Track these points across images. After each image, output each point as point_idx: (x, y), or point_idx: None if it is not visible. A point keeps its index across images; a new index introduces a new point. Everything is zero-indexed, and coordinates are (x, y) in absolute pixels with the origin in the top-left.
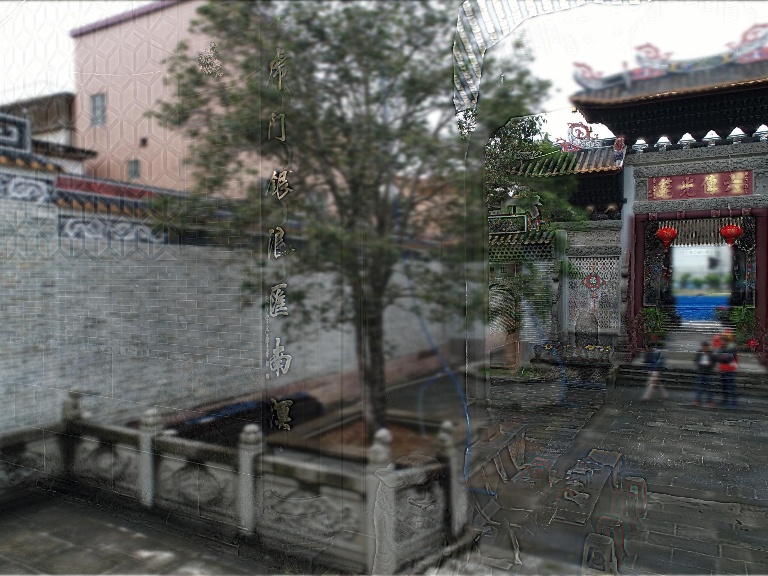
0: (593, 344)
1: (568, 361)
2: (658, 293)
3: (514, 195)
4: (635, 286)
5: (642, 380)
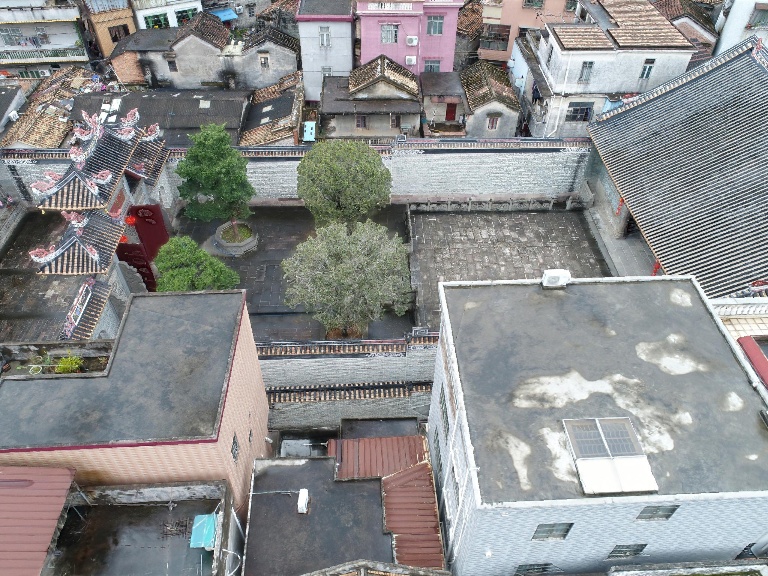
0: None
1: None
2: (621, 226)
3: (553, 34)
4: None
5: None
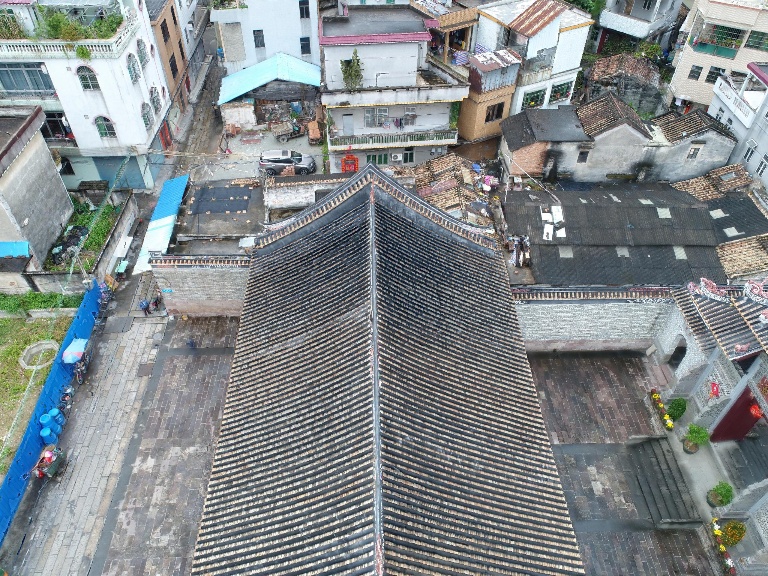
0: (671, 417)
1: (656, 411)
2: None
3: None
4: (727, 414)
5: (655, 453)
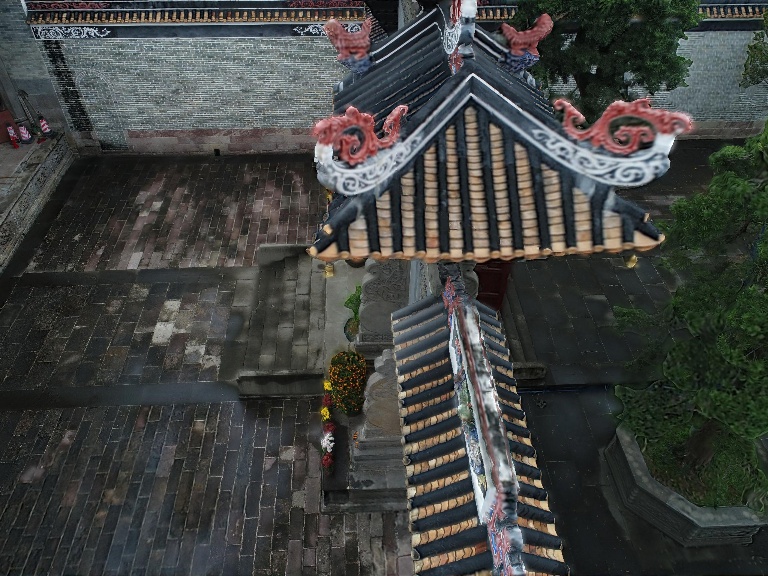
0: None
1: None
2: None
3: None
4: None
5: None
